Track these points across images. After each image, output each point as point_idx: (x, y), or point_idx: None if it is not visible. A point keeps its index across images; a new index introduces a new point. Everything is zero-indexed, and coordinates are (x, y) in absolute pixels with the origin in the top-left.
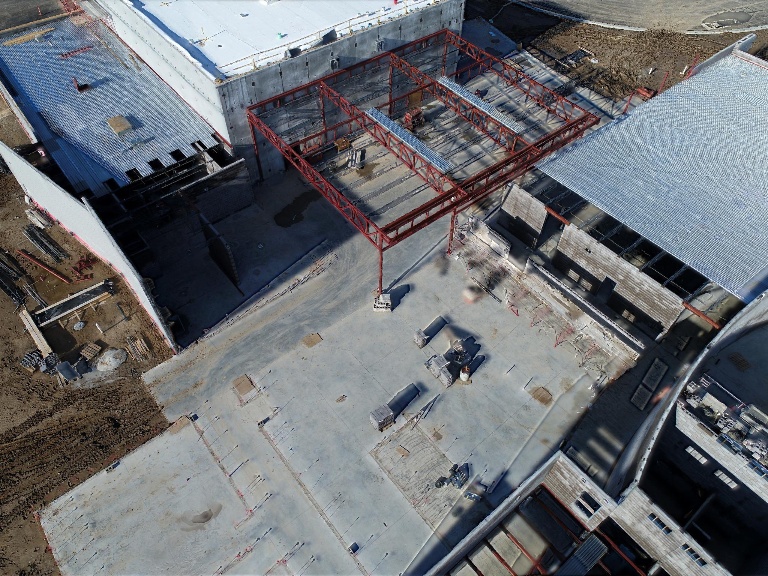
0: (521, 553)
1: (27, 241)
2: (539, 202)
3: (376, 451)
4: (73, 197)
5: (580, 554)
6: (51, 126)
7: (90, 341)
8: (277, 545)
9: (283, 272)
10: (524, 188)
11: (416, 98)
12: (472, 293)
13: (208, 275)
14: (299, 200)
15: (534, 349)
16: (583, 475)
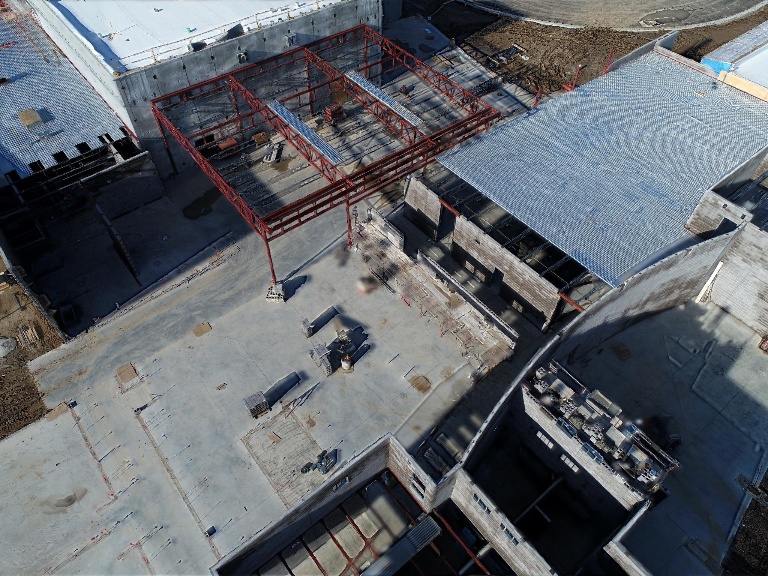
0: None
1: None
2: (433, 194)
3: (248, 437)
4: None
5: (413, 535)
6: None
7: None
8: (136, 528)
9: (183, 263)
10: (421, 180)
11: (339, 93)
12: (367, 284)
13: (108, 266)
14: (210, 193)
15: (420, 339)
16: (408, 456)
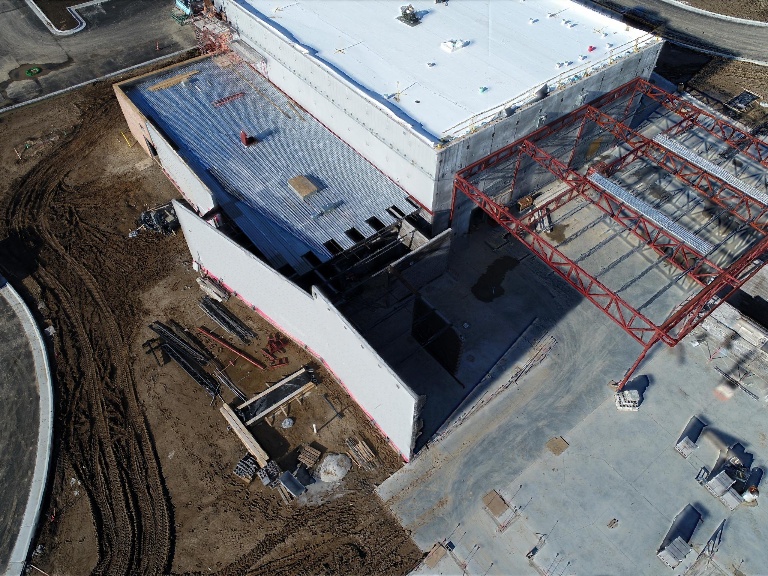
0: None
1: (205, 316)
2: None
3: None
4: (289, 281)
5: None
6: (225, 187)
7: (304, 443)
8: None
9: (501, 358)
10: None
11: (592, 149)
12: (721, 387)
13: (417, 361)
14: (493, 269)
15: None
16: None
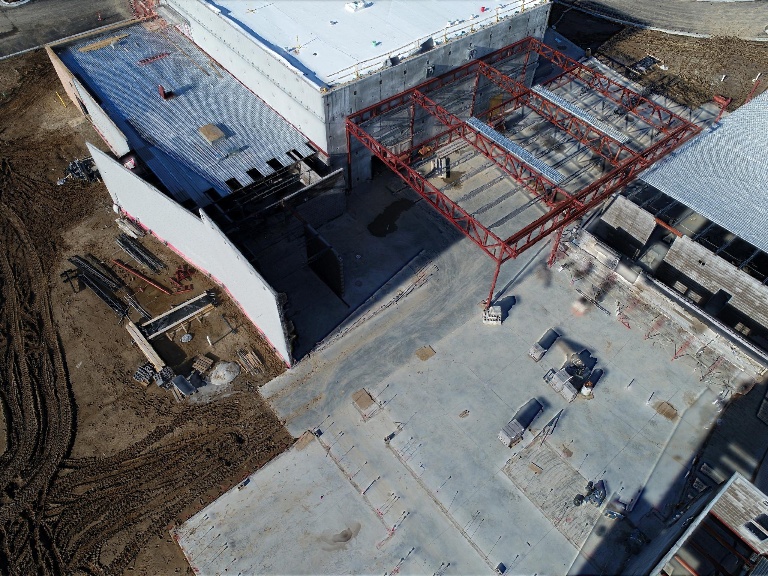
0: (671, 574)
1: (121, 251)
2: (648, 213)
3: (508, 468)
4: (184, 208)
5: None
6: (141, 134)
7: (200, 354)
8: (422, 565)
9: (385, 283)
10: (630, 199)
11: None
12: (579, 305)
13: (310, 286)
14: (390, 209)
15: (651, 363)
16: (766, 498)
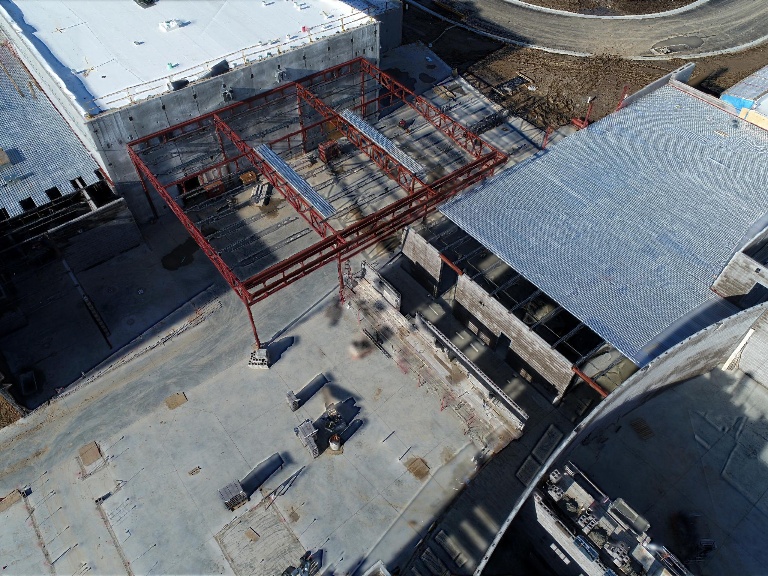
0: None
1: None
2: (433, 249)
3: (222, 534)
4: None
5: None
6: None
7: None
8: None
9: (159, 321)
10: (420, 233)
11: (334, 128)
12: (360, 347)
13: (77, 324)
14: (192, 240)
15: (418, 413)
16: None
